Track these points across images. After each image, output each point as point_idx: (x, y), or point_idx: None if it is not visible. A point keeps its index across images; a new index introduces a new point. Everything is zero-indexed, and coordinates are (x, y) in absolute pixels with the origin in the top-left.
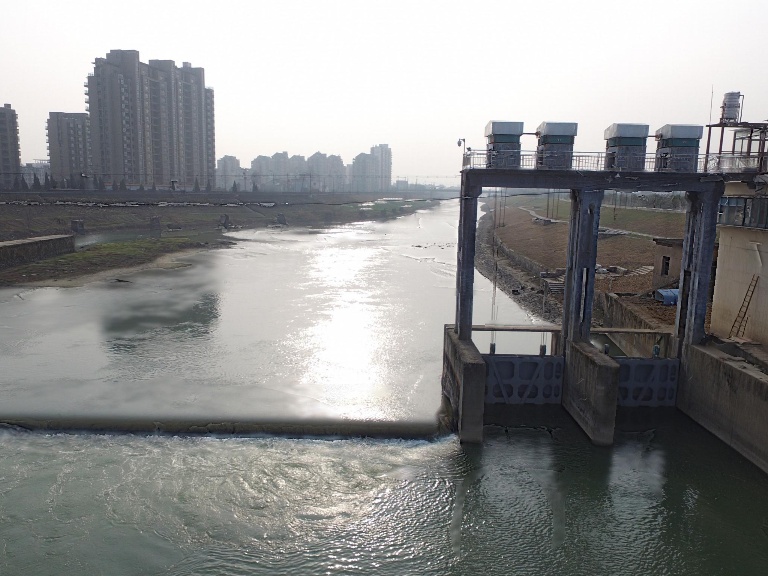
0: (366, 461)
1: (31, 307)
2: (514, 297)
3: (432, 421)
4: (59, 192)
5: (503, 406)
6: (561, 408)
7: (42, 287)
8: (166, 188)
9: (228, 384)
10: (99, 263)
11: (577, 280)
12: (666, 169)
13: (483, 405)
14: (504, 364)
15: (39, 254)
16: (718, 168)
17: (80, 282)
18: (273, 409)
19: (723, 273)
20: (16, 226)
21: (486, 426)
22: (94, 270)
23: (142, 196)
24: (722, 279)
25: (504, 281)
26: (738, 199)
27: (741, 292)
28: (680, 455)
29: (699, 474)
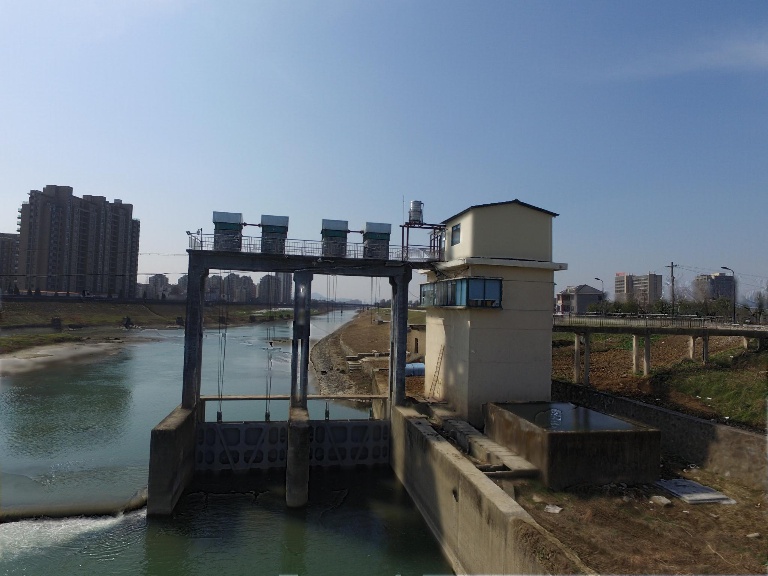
0: (14, 546)
1: None
2: (320, 376)
3: (133, 493)
4: None
5: (229, 472)
6: (284, 471)
7: None
8: (76, 295)
9: None
10: None
11: (293, 350)
12: (361, 256)
13: (171, 473)
14: (230, 431)
15: None
16: (407, 258)
17: None
18: None
19: (428, 345)
20: None
21: (191, 494)
22: None
23: (51, 301)
24: (428, 350)
25: (322, 365)
26: (430, 284)
27: (436, 360)
28: (355, 511)
29: (361, 530)
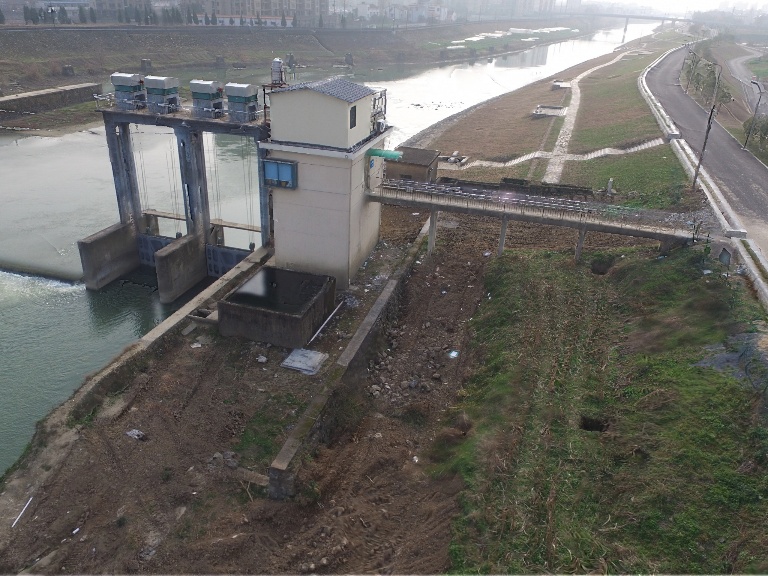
0: (21, 291)
1: (6, 154)
2: None
3: None
4: (144, 29)
5: None
6: None
7: (33, 135)
8: (245, 24)
9: (28, 231)
10: (98, 113)
11: None
12: (217, 120)
13: (93, 268)
14: (157, 242)
15: (64, 101)
16: (265, 119)
17: (64, 132)
18: (22, 252)
19: None
20: (94, 64)
21: (120, 281)
22: (87, 120)
23: (220, 32)
24: None
25: None
26: None
27: None
28: None
29: None
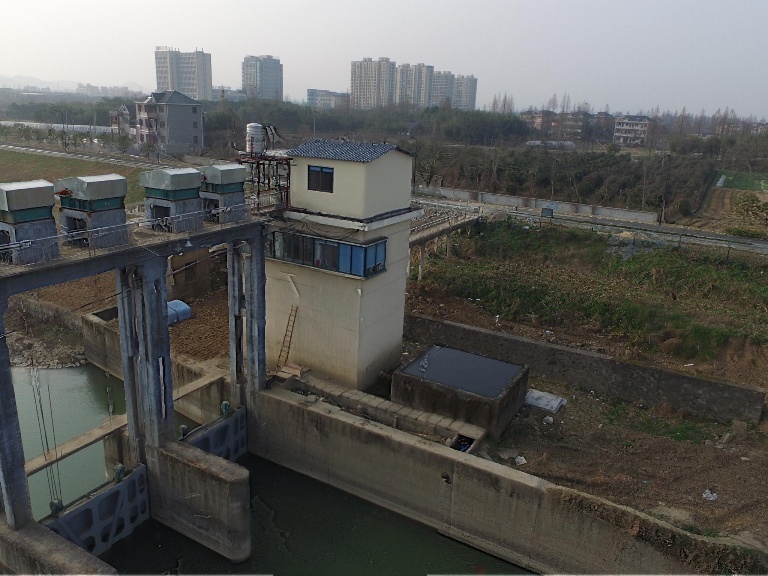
0: None
1: None
2: None
3: None
4: None
5: None
6: (155, 524)
7: None
8: None
9: None
10: None
11: (154, 376)
12: (228, 224)
13: None
14: (78, 517)
15: None
16: (259, 209)
17: None
18: None
19: None
20: None
21: None
22: None
23: None
24: None
25: None
26: None
27: (278, 320)
28: (318, 529)
29: (349, 545)
